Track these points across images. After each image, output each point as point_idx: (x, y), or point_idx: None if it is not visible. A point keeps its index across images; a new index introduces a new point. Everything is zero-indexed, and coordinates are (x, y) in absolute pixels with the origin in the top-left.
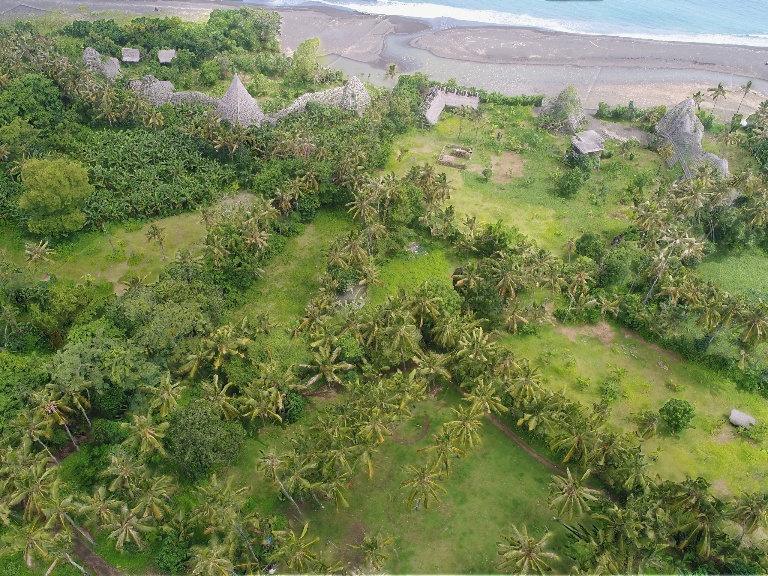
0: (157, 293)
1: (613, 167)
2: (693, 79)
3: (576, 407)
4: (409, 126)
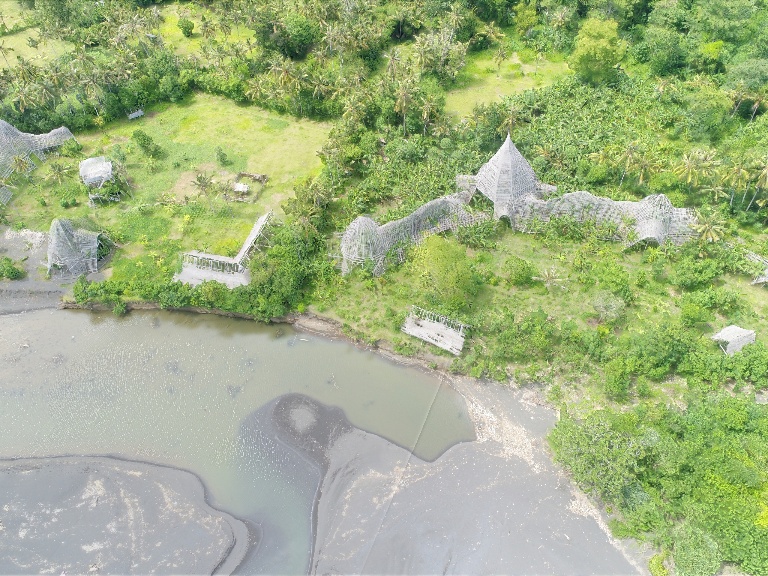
0: None
1: (76, 191)
2: None
3: None
4: None
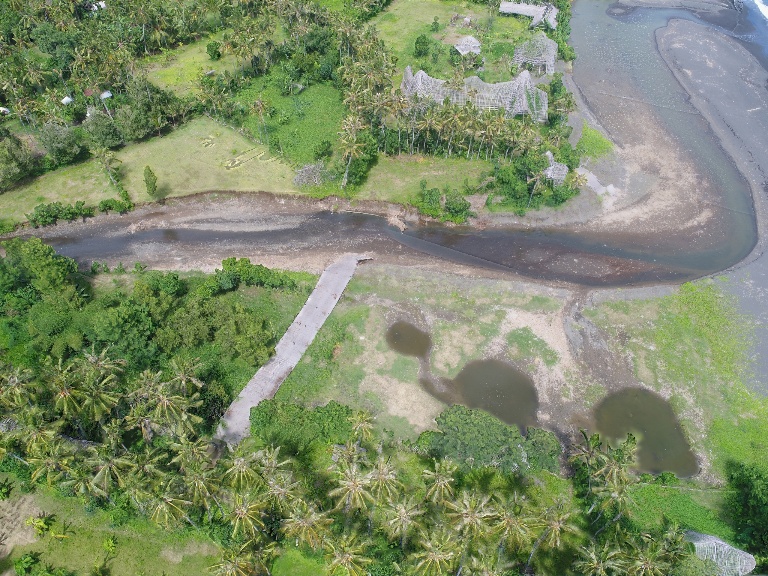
0: None
1: None
2: (711, 175)
3: (211, 1)
4: None
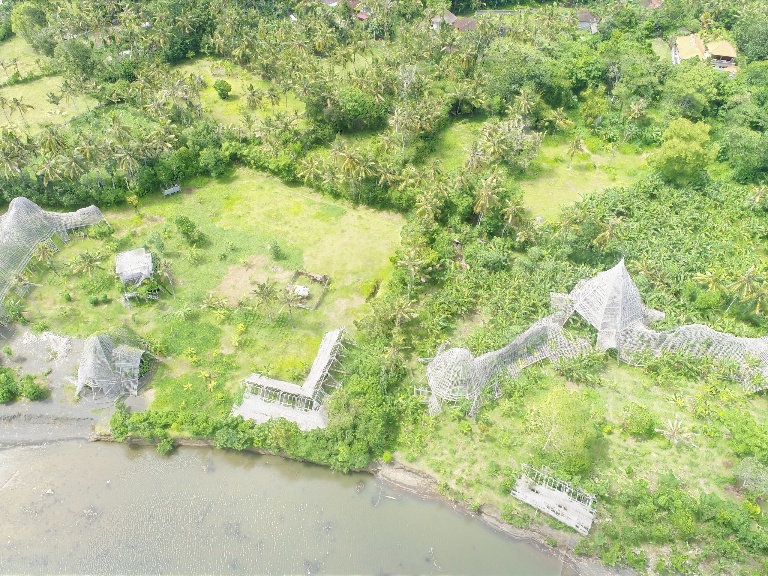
0: (519, 54)
1: (106, 284)
2: None
3: None
4: (365, 343)
